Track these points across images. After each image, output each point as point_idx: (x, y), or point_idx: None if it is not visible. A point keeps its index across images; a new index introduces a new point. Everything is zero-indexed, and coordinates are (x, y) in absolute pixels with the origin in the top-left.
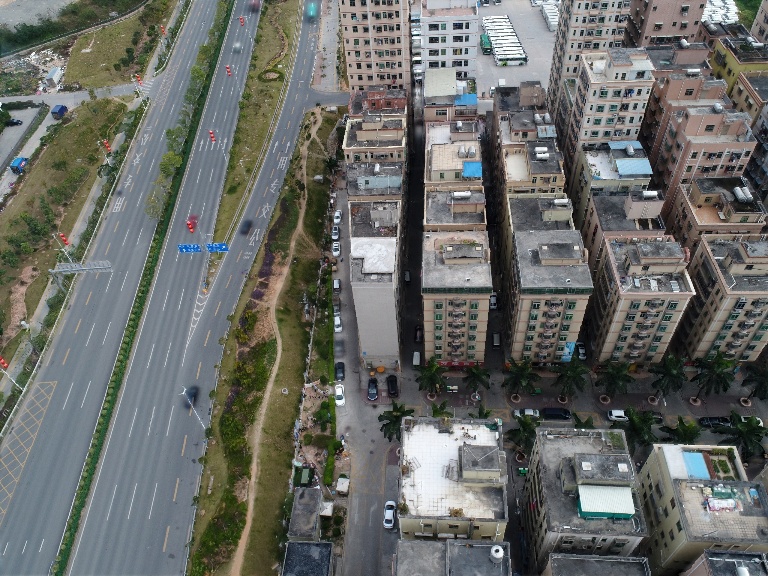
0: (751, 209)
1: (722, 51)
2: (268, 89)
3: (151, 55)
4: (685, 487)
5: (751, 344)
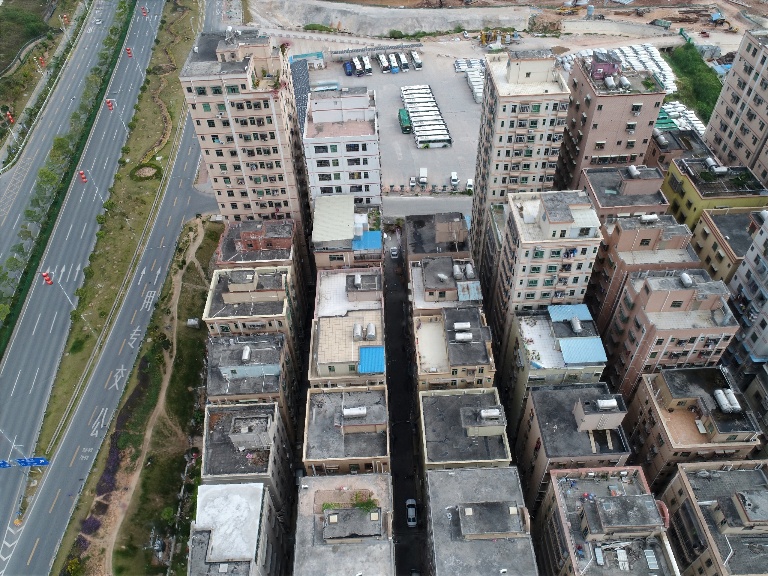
0: (740, 425)
1: (678, 177)
2: (140, 191)
3: (1, 144)
4: None
5: None
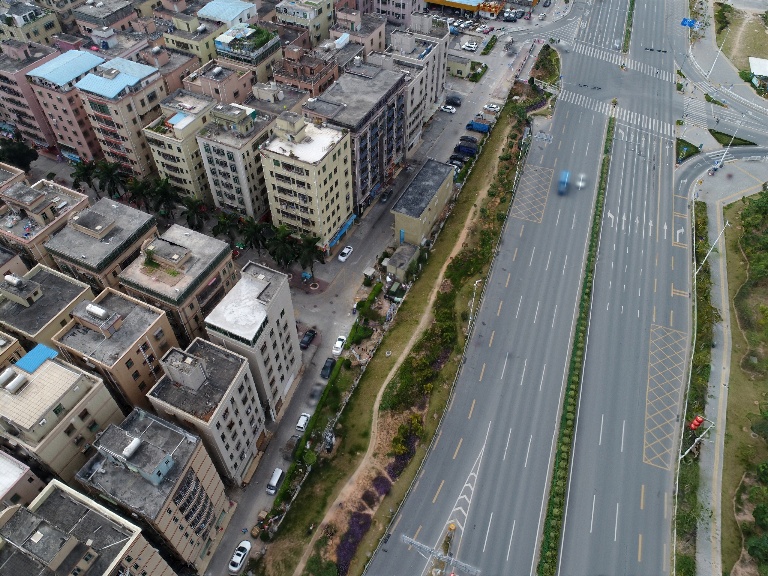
0: None
1: None
2: None
3: None
4: None
5: None
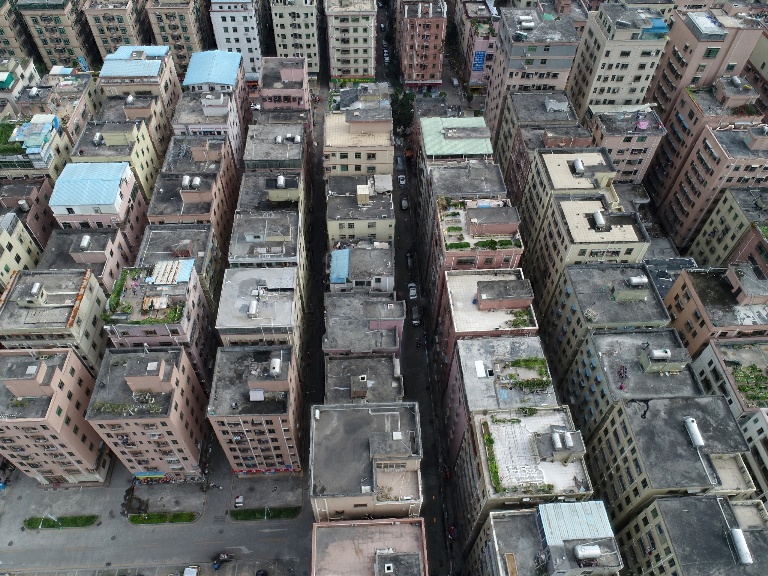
0: None
1: None
2: None
3: None
4: (52, 79)
5: (189, 55)
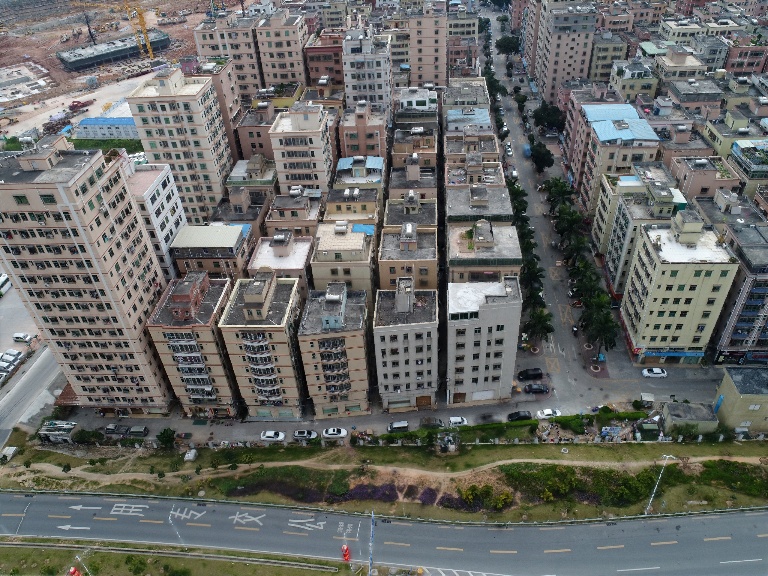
0: (430, 132)
1: None
2: None
3: None
4: None
5: None
